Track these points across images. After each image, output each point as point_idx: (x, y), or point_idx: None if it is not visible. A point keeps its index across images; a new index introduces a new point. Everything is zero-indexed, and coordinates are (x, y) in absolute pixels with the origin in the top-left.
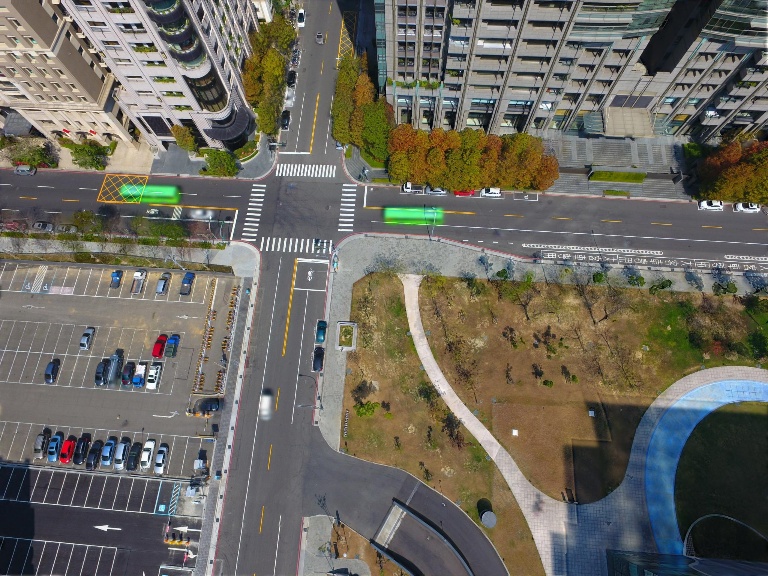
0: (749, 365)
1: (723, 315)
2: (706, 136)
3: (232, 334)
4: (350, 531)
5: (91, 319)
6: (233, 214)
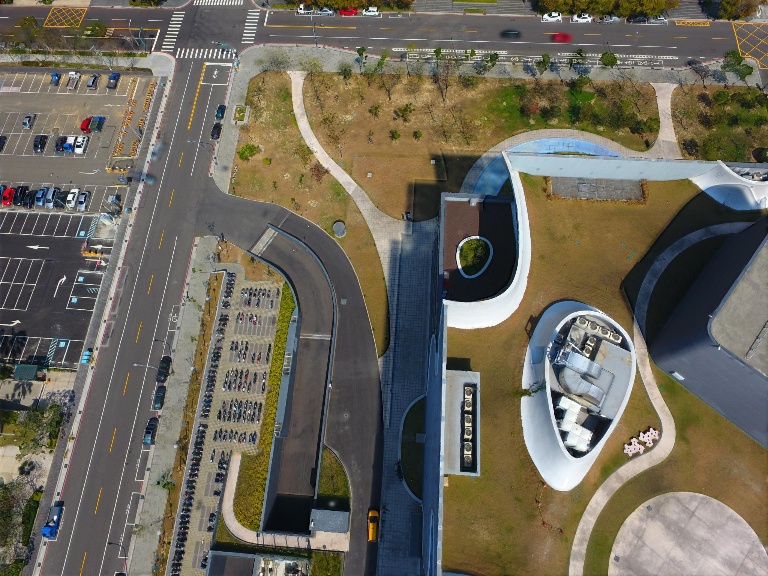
0: (566, 128)
1: (550, 94)
2: None
3: (148, 116)
4: (231, 245)
5: (33, 108)
6: (155, 33)
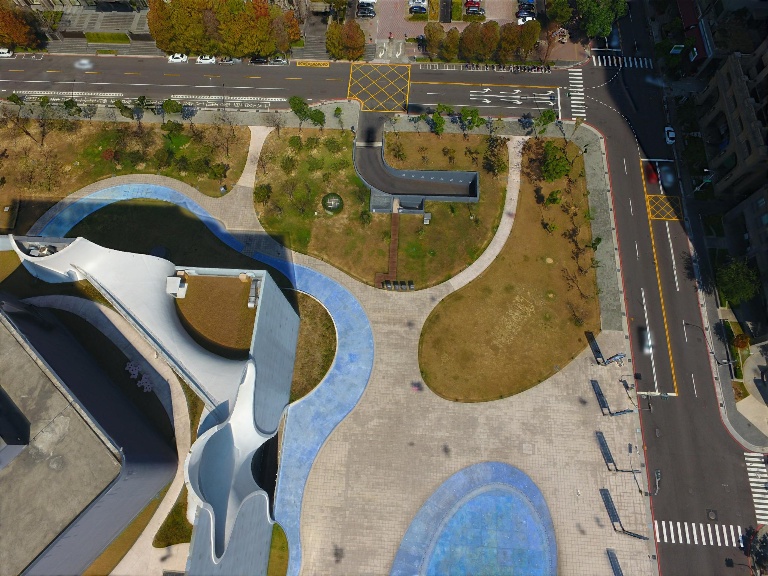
0: (151, 173)
1: (148, 138)
2: None
3: None
4: None
5: None
6: None
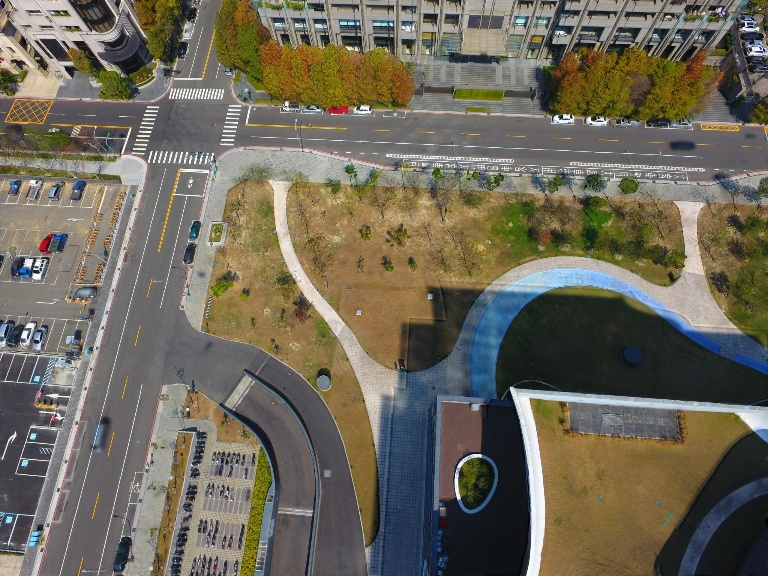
0: (580, 255)
1: (562, 213)
2: (561, 57)
3: (115, 233)
4: (203, 397)
5: None
6: (126, 132)
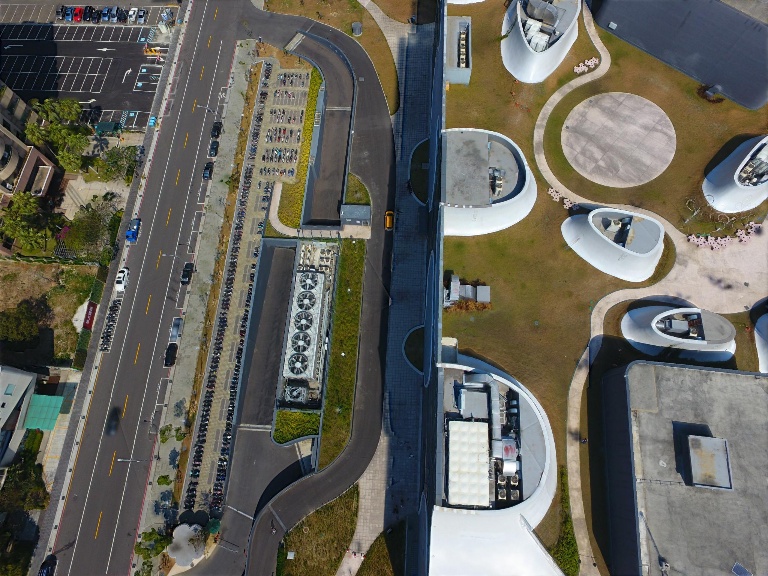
0: None
1: None
2: None
3: None
4: (267, 45)
5: None
6: None
